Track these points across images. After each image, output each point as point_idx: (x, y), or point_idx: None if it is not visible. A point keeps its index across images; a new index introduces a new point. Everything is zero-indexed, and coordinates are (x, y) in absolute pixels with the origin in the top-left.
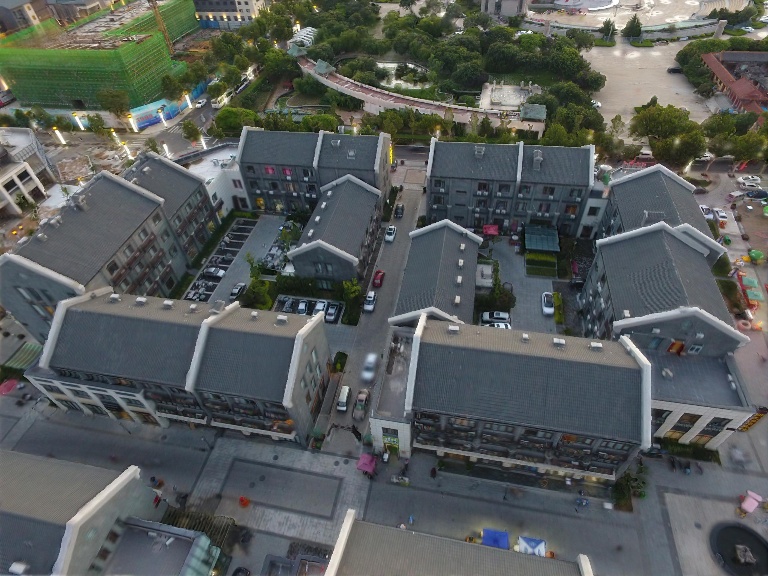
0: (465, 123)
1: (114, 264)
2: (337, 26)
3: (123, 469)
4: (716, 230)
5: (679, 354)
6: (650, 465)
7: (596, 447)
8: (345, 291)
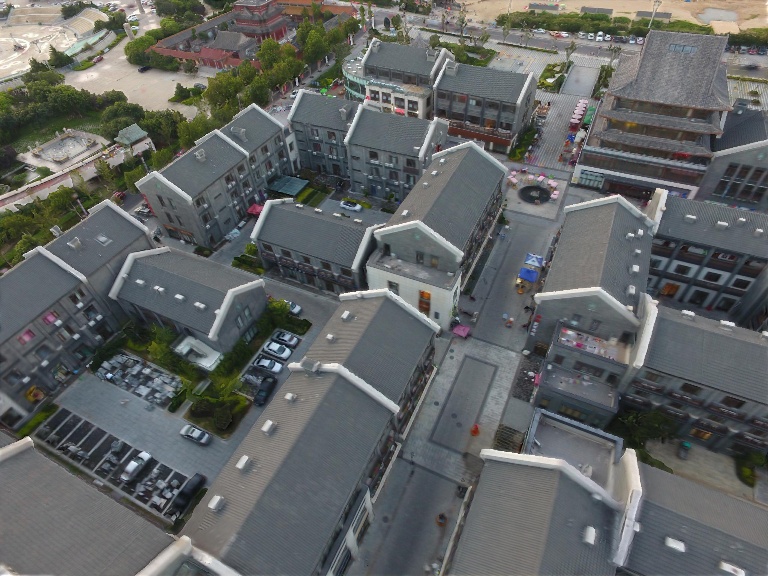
0: None
1: None
2: None
3: (414, 568)
4: None
5: None
6: None
7: None
8: (278, 312)
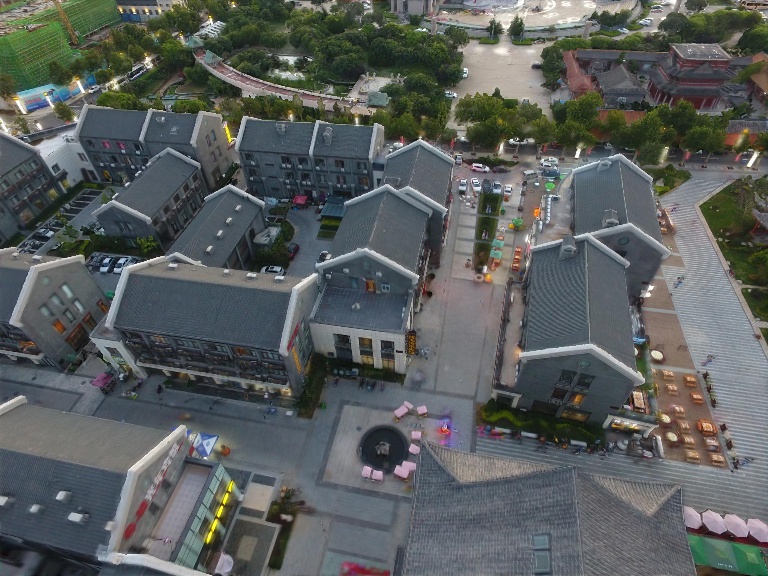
0: None
1: None
2: (242, 21)
3: None
4: (498, 202)
5: (375, 292)
6: (344, 385)
7: (259, 358)
8: (141, 247)
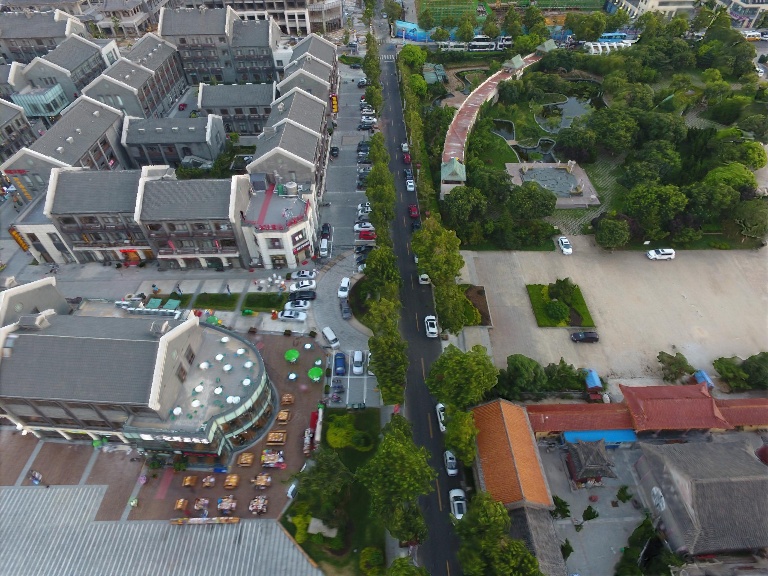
0: None
1: (185, 40)
2: (637, 51)
3: None
4: (265, 308)
5: None
6: None
7: None
8: None
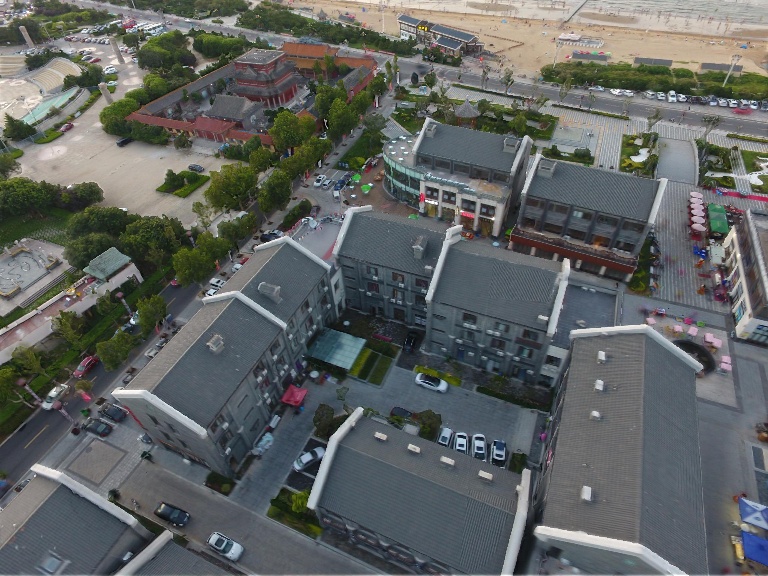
0: (34, 345)
1: None
2: None
3: None
4: None
5: None
6: None
7: None
8: None
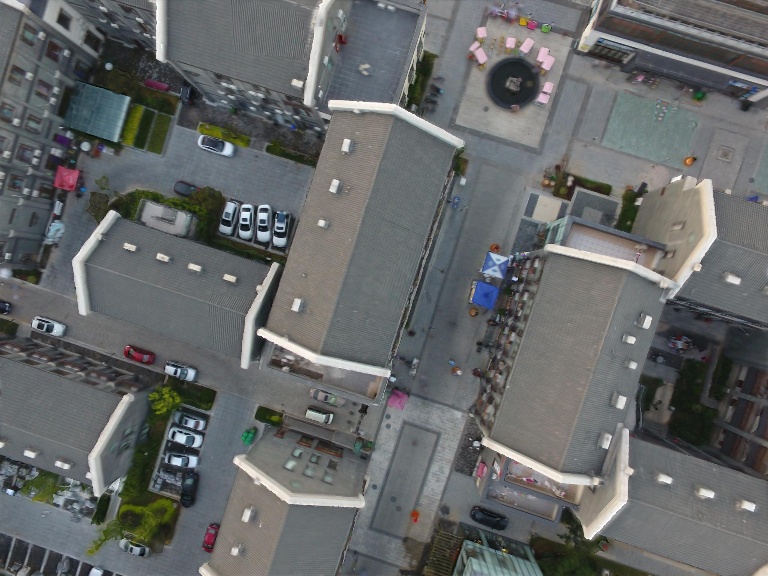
0: None
1: None
2: None
3: None
4: None
5: (343, 42)
6: None
7: None
8: None
